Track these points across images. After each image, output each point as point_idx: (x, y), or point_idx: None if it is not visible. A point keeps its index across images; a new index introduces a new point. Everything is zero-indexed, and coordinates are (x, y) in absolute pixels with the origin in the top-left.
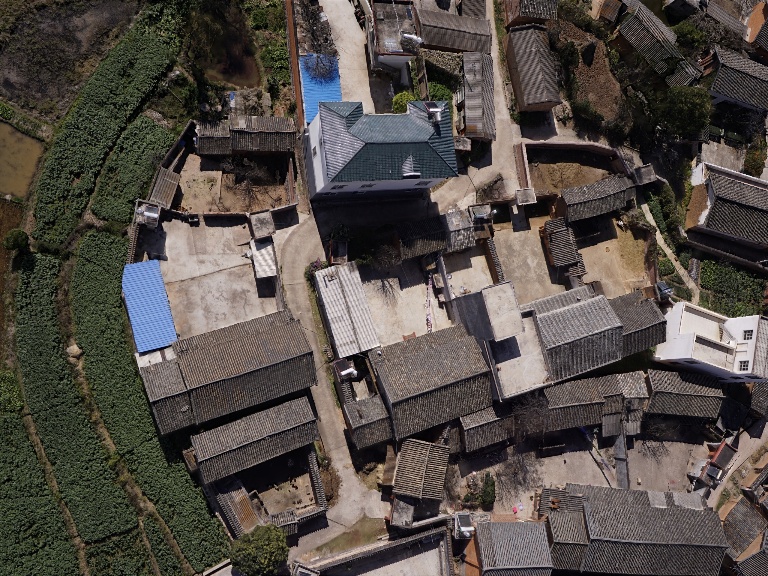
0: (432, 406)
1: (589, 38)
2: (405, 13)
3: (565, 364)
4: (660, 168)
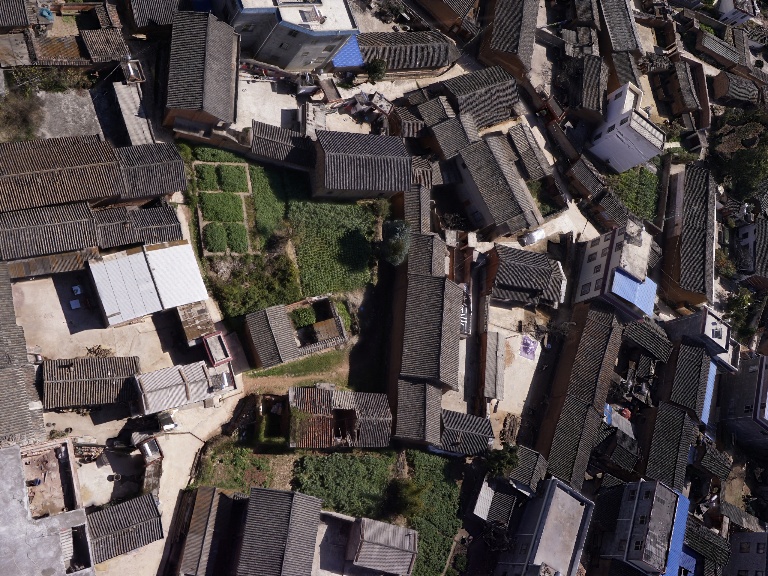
0: None
1: None
2: (750, 11)
3: (612, 6)
4: None
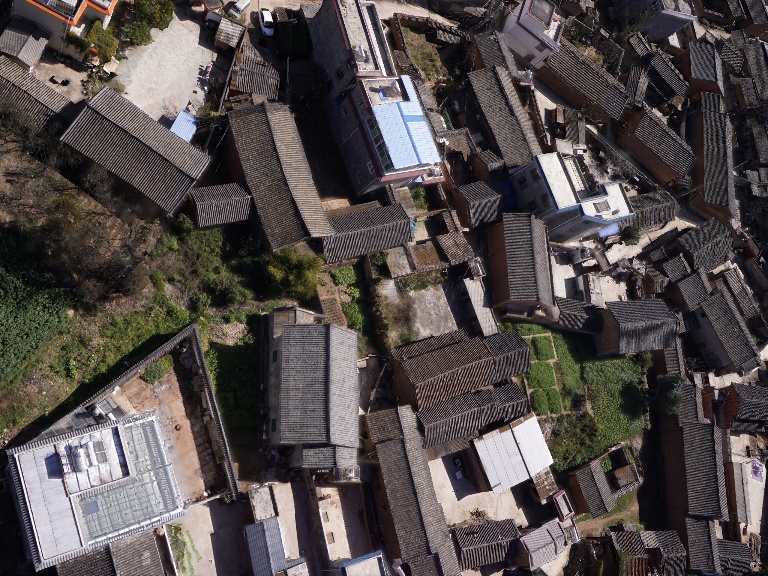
0: (760, 65)
1: None
2: None
3: None
4: None
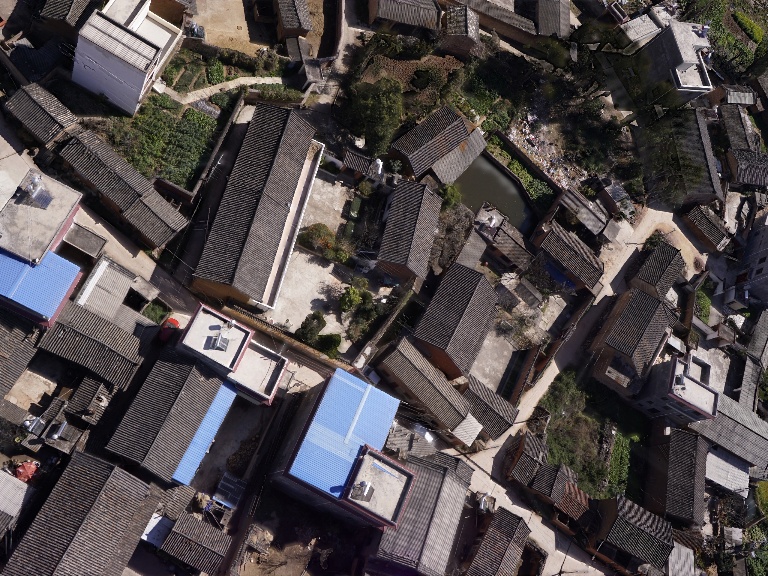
0: None
1: (435, 91)
2: None
3: None
4: (317, 121)
